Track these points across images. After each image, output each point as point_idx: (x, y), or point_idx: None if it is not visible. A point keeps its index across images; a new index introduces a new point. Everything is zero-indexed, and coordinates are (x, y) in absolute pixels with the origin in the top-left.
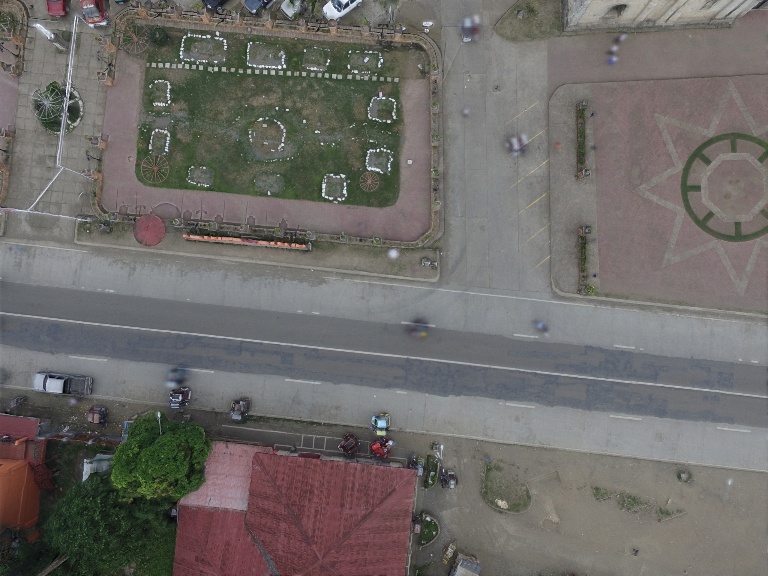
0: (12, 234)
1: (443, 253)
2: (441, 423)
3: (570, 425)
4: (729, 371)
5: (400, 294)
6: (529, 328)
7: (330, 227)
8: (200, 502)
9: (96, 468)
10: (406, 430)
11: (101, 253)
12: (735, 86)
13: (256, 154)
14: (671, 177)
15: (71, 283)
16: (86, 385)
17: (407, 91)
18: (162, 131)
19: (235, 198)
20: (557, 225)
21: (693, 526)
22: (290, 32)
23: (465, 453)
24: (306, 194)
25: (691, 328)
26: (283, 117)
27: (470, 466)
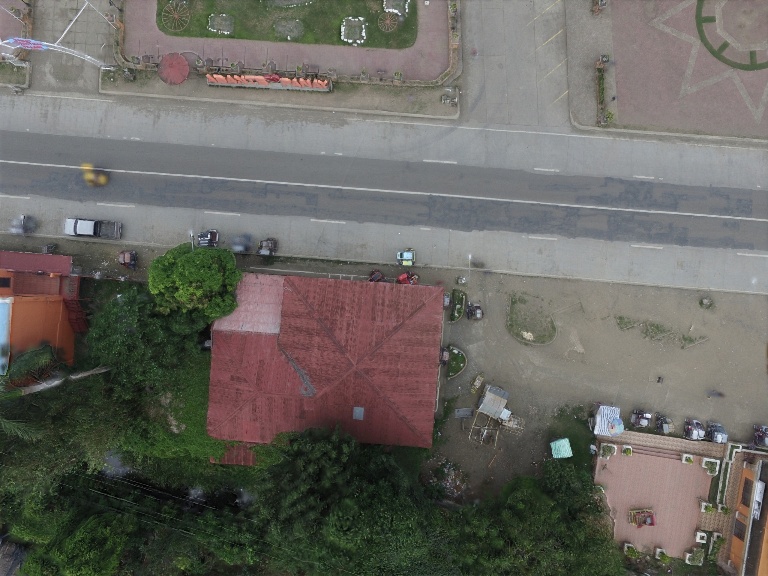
0: (37, 87)
1: (462, 92)
2: (465, 258)
3: (592, 256)
4: (748, 198)
5: (421, 133)
6: (549, 162)
7: (350, 70)
8: (233, 327)
9: None
10: (431, 266)
11: (125, 102)
12: None
13: (275, 0)
14: (686, 9)
15: (97, 132)
16: (116, 228)
17: None
18: None
19: (255, 44)
20: (574, 60)
21: (716, 352)
22: None
23: (490, 287)
24: (325, 38)
25: (709, 157)
26: None
27: (495, 300)
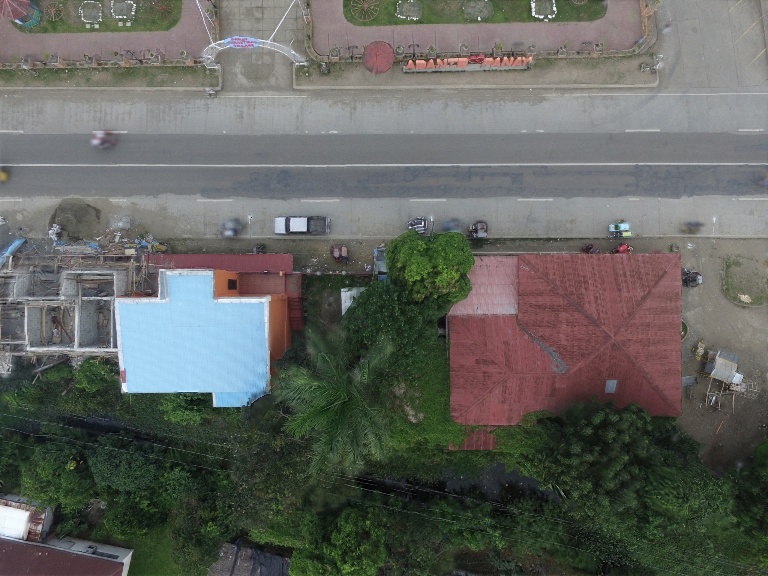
0: (229, 88)
1: (658, 59)
2: (676, 225)
3: None
4: None
5: (621, 103)
6: (753, 122)
7: (543, 46)
8: (468, 311)
9: (356, 294)
10: (642, 236)
11: (320, 96)
12: None
13: None
14: None
15: (294, 129)
16: (327, 222)
17: None
18: None
19: (445, 28)
20: None
21: None
22: None
23: (703, 253)
24: (515, 16)
25: None
26: None
27: (708, 265)
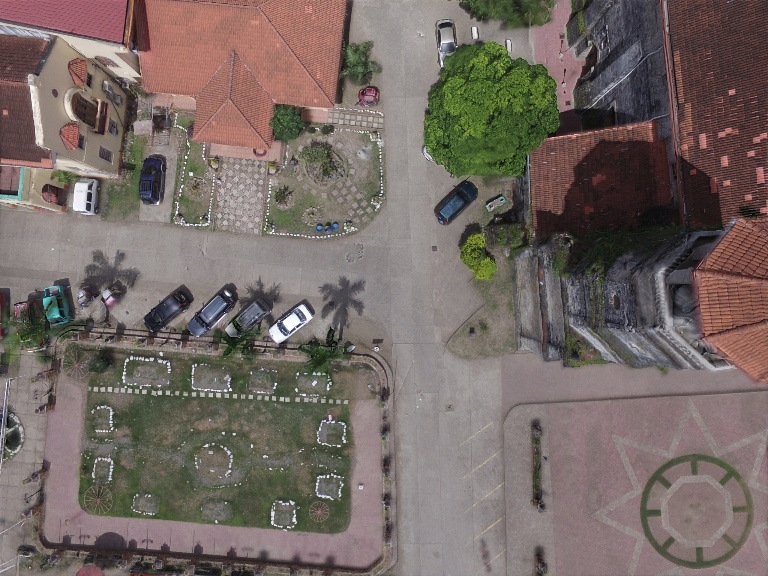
0: None
1: None
2: None
3: None
4: None
5: None
6: None
7: (280, 555)
8: None
9: None
10: None
11: None
12: (695, 405)
13: (203, 481)
14: (630, 501)
15: None
16: None
17: (357, 412)
18: (105, 460)
19: (182, 526)
20: (513, 552)
21: None
22: (236, 352)
23: None
24: (255, 521)
25: None
26: (230, 442)
27: None
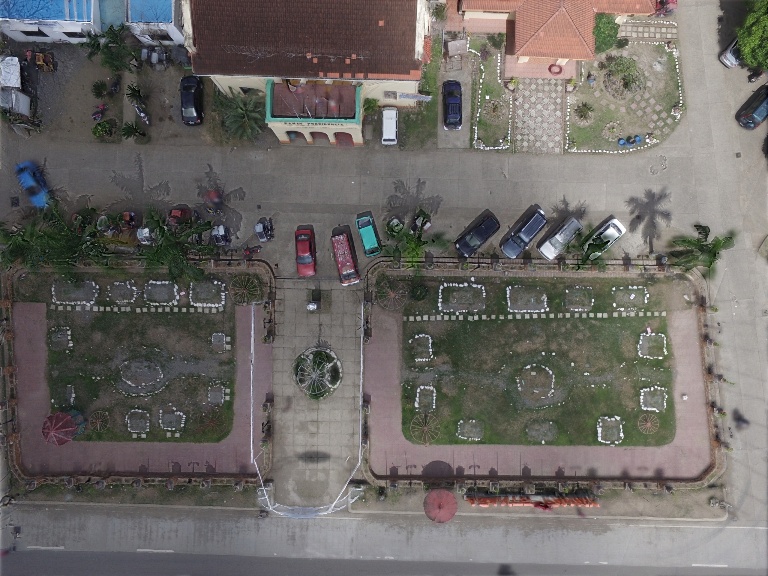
0: (281, 506)
1: (727, 489)
2: None
3: None
4: None
5: (688, 536)
6: None
7: (608, 471)
8: None
9: None
10: None
11: (376, 519)
12: None
13: (526, 402)
14: None
15: (348, 553)
16: None
17: (674, 323)
18: (428, 388)
19: (508, 449)
20: None
21: None
22: (548, 272)
23: None
24: (581, 439)
25: None
26: (550, 361)
27: None
